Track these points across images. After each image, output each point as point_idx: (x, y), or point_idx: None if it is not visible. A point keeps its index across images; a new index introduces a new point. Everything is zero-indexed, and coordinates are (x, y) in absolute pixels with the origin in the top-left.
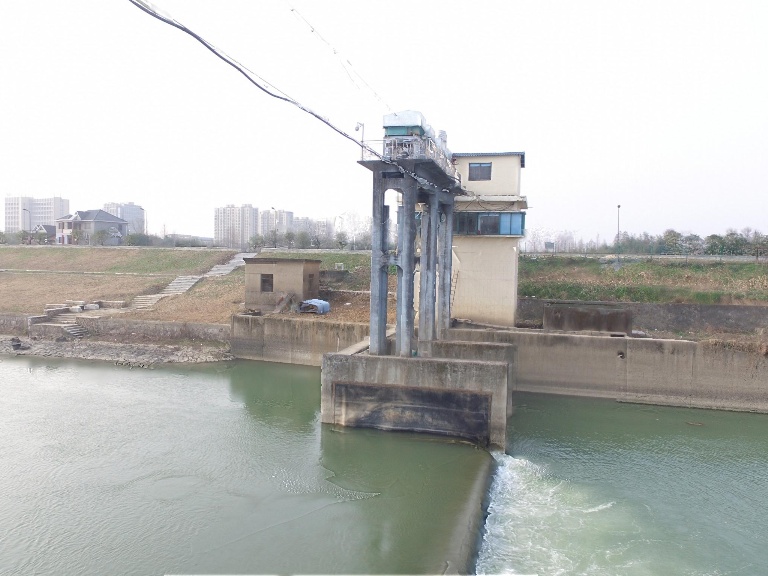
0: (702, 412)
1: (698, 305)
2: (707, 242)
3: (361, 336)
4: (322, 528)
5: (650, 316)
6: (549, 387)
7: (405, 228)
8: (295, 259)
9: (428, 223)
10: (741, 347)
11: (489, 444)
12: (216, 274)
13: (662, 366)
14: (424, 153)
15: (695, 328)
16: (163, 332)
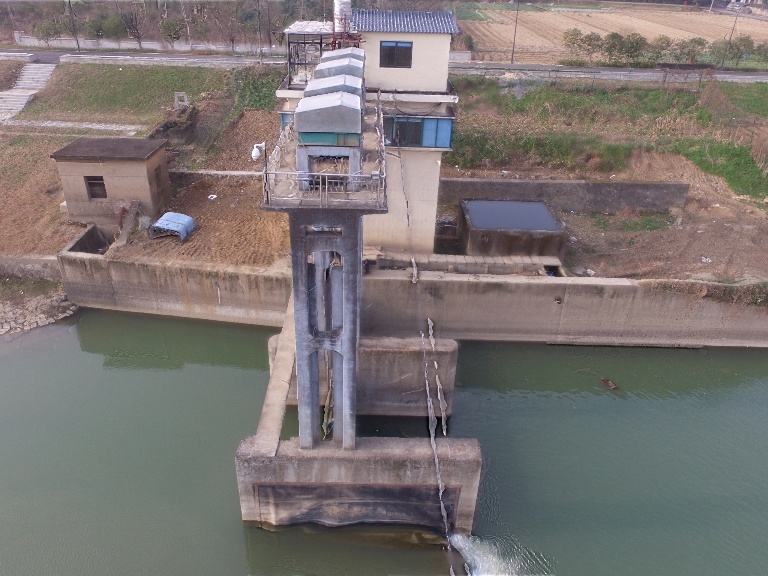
0: (630, 351)
1: (619, 184)
2: (607, 42)
3: (249, 287)
4: None
5: (568, 197)
6: (477, 334)
7: (345, 306)
8: (132, 157)
9: None
10: (682, 289)
11: (454, 528)
12: (3, 111)
13: (599, 310)
14: (374, 199)
15: (611, 209)
16: None
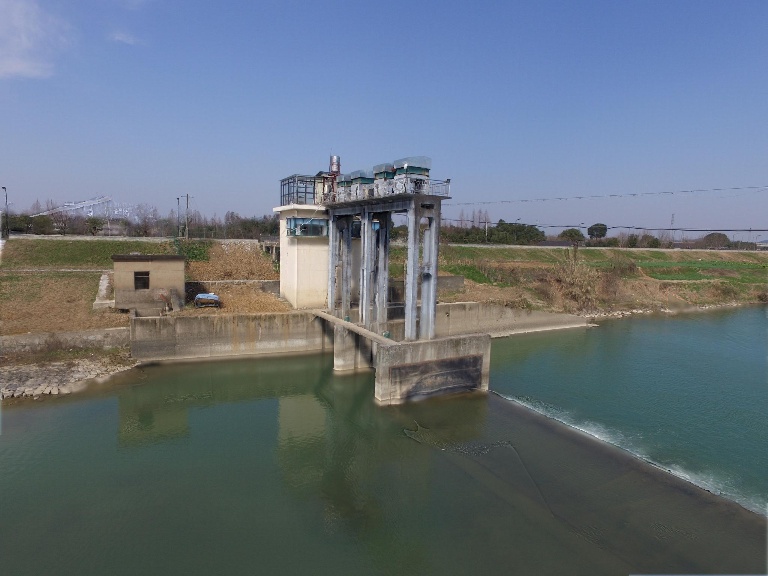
0: None
1: None
2: None
3: (282, 323)
4: (548, 467)
5: None
6: None
7: (435, 246)
8: (176, 256)
9: (385, 235)
10: (496, 303)
11: (481, 386)
12: None
13: (465, 318)
14: (446, 192)
15: None
16: (16, 348)
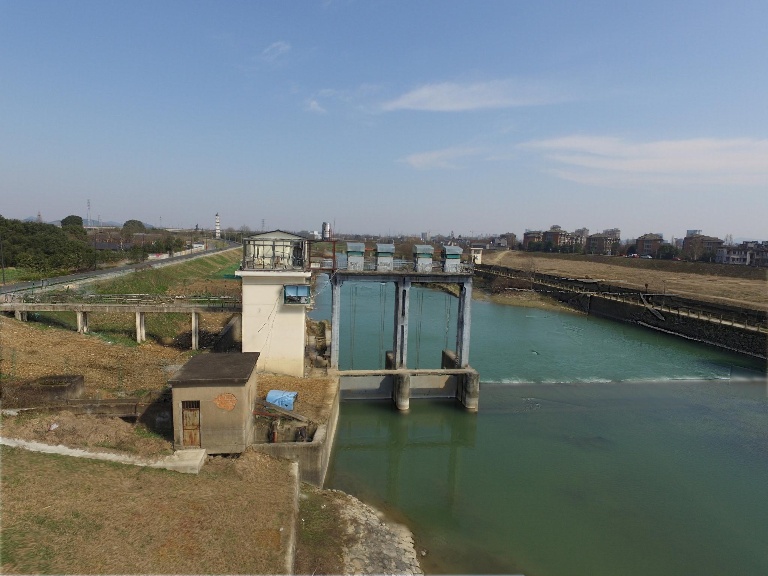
0: None
1: None
2: None
3: None
4: None
5: None
6: None
7: None
8: None
9: None
10: None
11: None
12: None
13: None
14: None
15: None
16: None
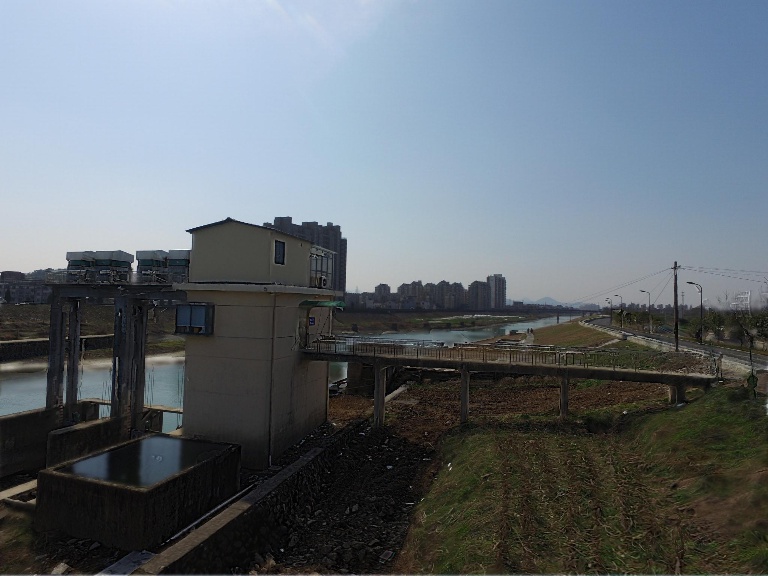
0: None
1: None
2: None
3: None
4: None
5: None
6: None
7: None
8: None
9: None
10: None
11: None
12: None
13: None
14: None
15: None
16: None
